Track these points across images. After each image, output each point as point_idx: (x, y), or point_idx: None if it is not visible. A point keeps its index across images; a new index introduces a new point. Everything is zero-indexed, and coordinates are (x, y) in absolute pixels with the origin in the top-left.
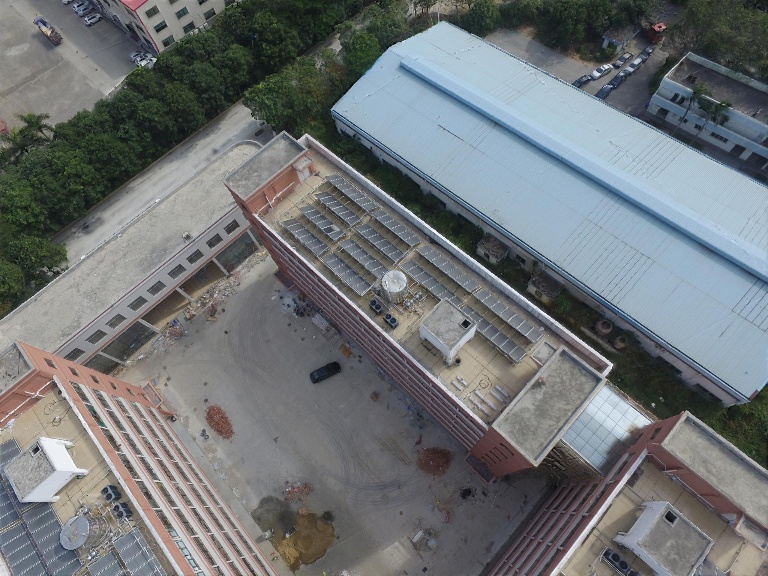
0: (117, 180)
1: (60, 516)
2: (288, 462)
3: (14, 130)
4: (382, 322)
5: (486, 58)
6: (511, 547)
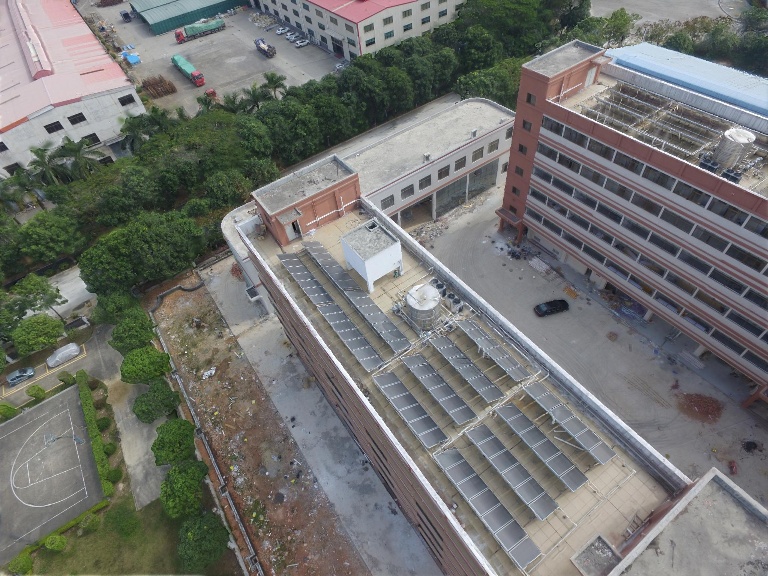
0: (323, 144)
1: (377, 305)
2: None
3: (255, 86)
4: None
5: (701, 64)
6: None
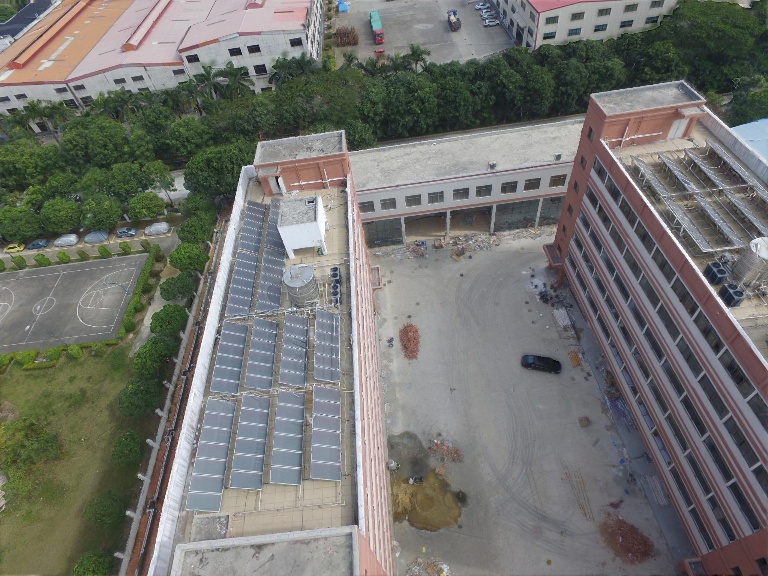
0: (442, 127)
1: None
2: (452, 418)
3: (400, 54)
4: None
5: None
6: None
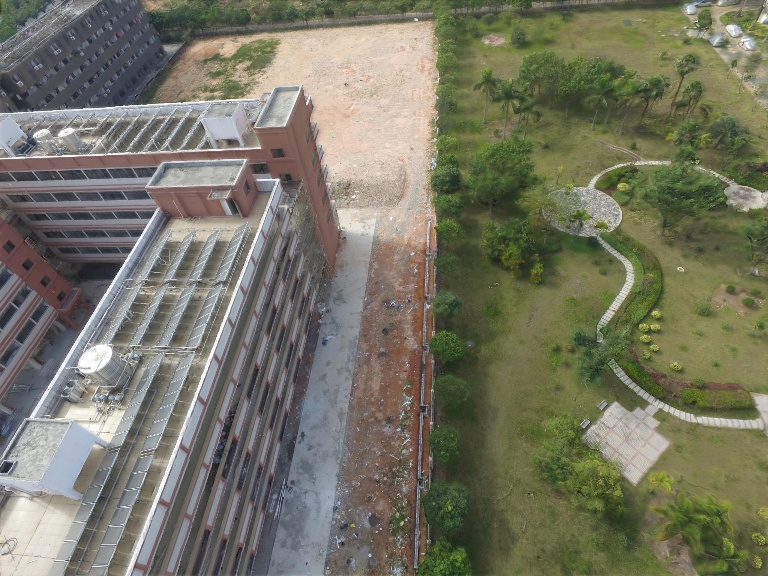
0: None
1: None
2: None
3: None
4: None
5: None
6: (117, 259)
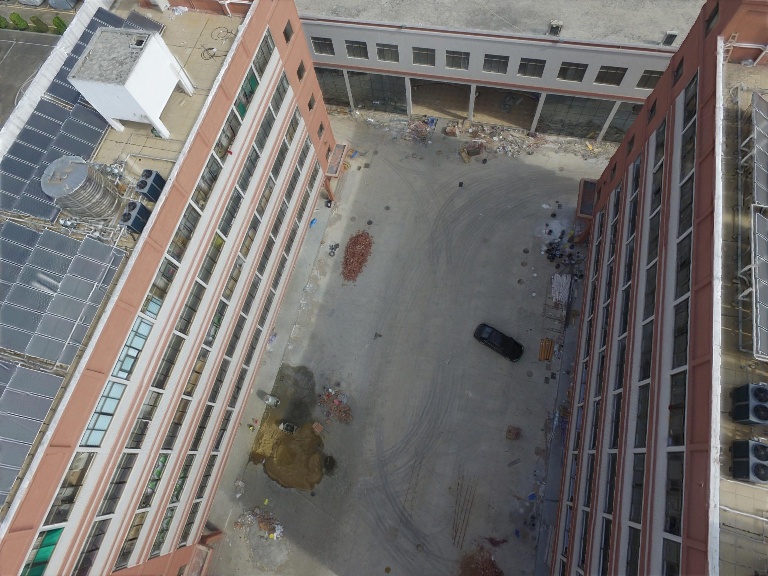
0: None
1: (103, 149)
2: (361, 369)
3: None
4: (724, 438)
5: None
6: None
